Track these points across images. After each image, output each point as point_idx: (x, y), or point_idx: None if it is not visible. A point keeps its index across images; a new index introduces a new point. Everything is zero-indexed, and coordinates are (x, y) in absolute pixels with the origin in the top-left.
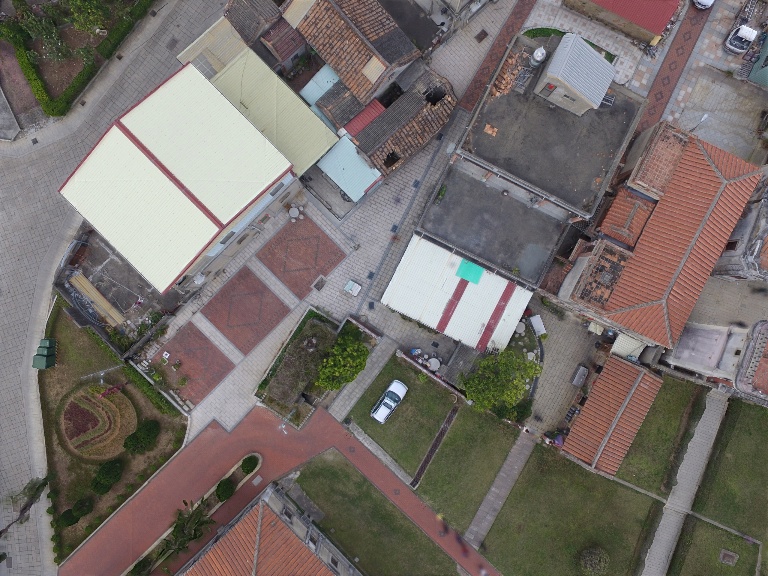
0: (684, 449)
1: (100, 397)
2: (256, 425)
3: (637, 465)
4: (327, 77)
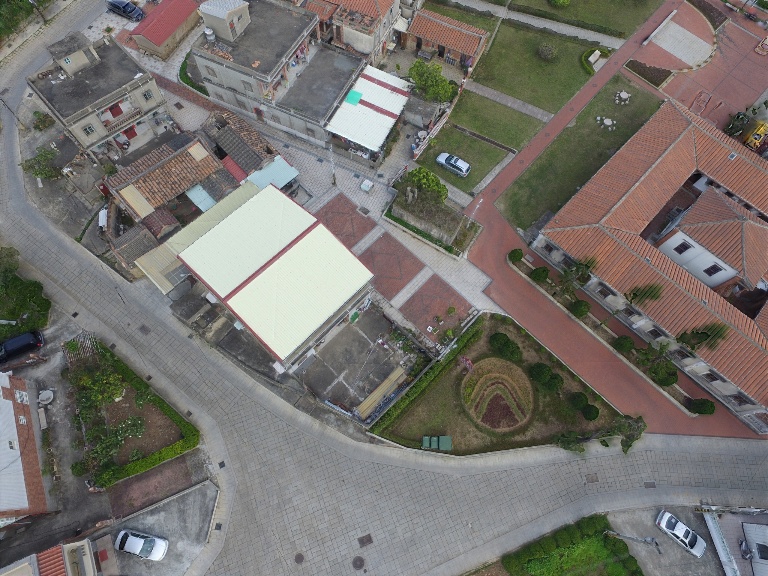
0: (466, 7)
1: (471, 363)
2: (483, 259)
3: None
4: (197, 194)
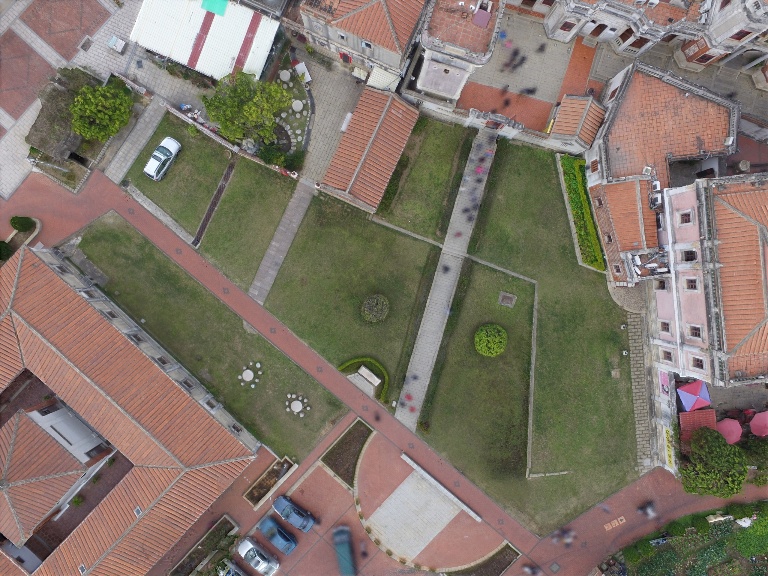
0: (454, 190)
1: None
2: (33, 191)
3: (411, 211)
4: None
